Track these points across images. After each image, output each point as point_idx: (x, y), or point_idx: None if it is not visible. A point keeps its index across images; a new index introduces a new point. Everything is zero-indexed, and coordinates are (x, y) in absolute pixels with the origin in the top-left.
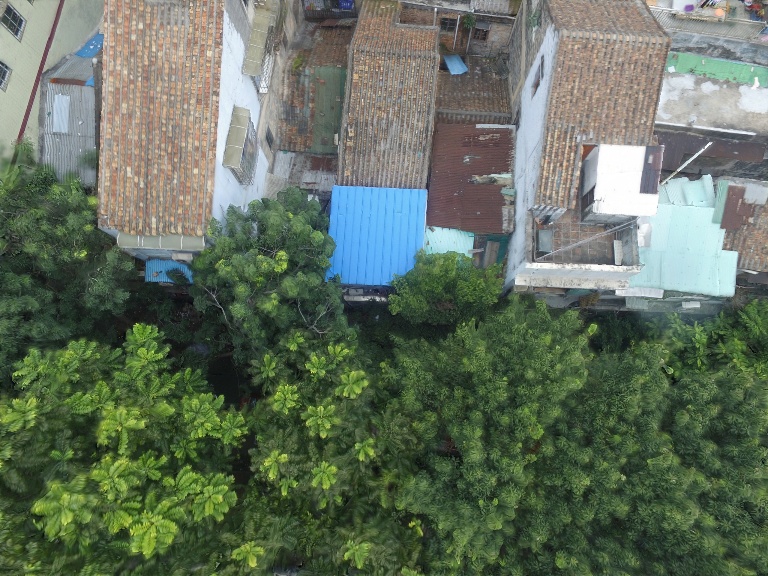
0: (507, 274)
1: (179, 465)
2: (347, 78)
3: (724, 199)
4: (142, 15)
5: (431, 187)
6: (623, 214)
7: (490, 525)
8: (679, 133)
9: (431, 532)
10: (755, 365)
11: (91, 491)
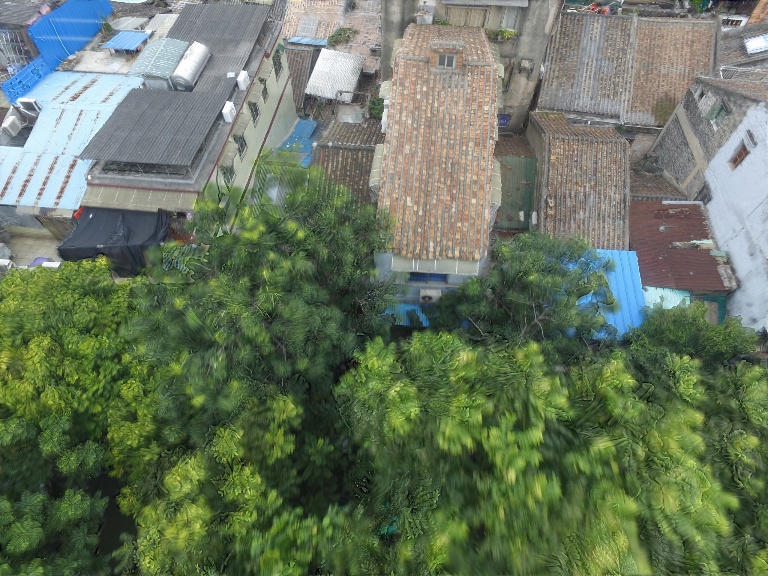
0: None
1: None
2: (545, 159)
3: None
4: (426, 81)
5: None
6: None
7: None
8: None
9: None
10: None
11: None
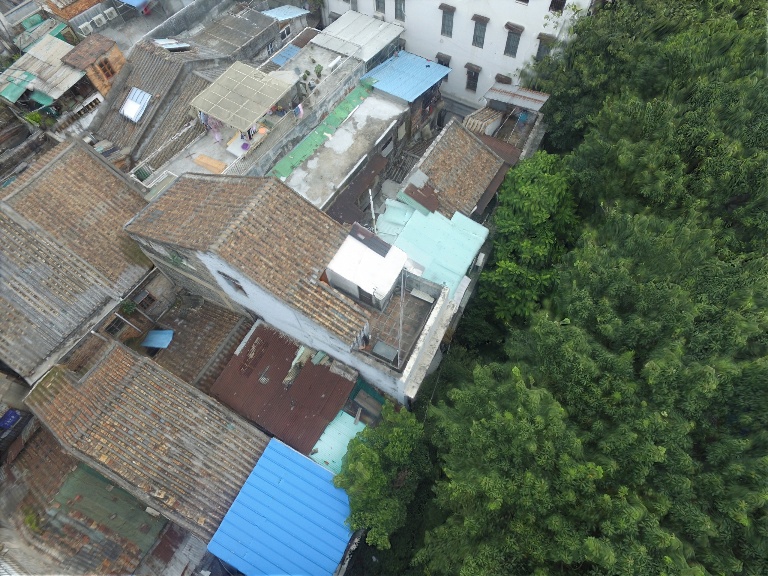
0: (394, 397)
1: None
2: (97, 469)
3: (412, 200)
4: None
5: (270, 430)
6: (396, 278)
7: None
8: (337, 199)
9: None
10: (546, 242)
11: None
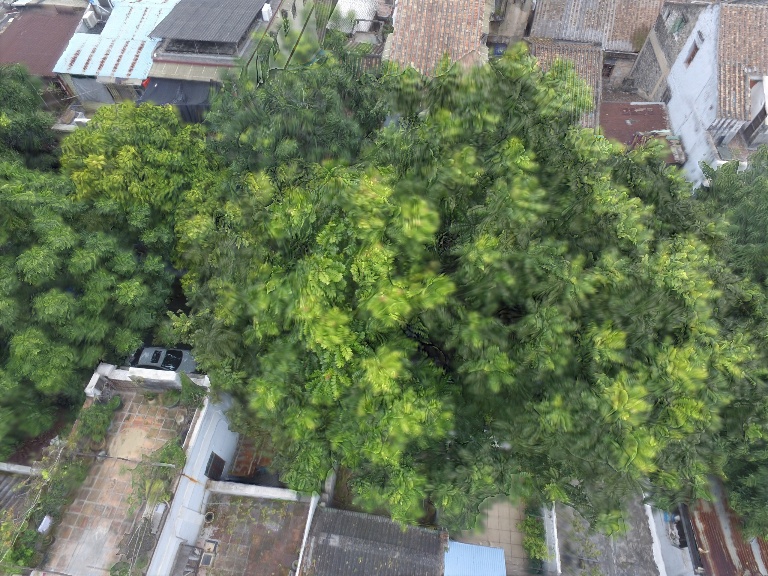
0: None
1: None
2: None
3: None
4: None
5: None
6: None
7: None
8: None
9: None
10: None
11: None
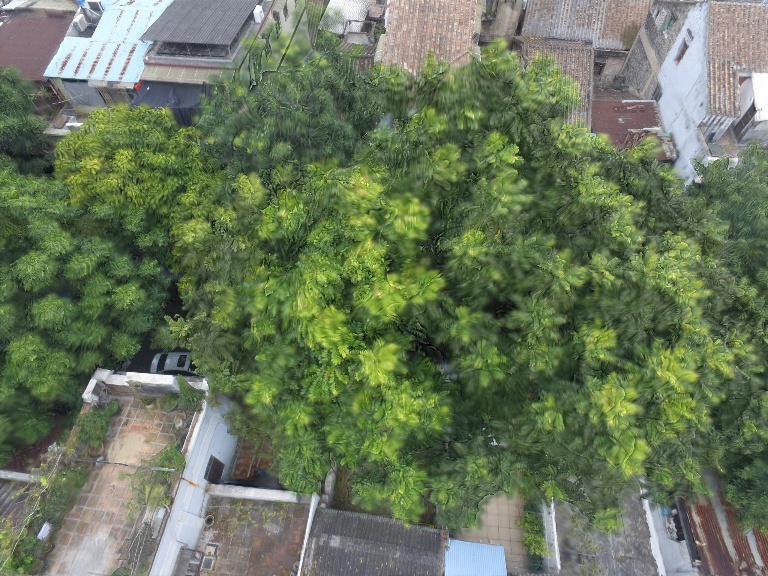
0: None
1: None
2: None
3: None
4: None
5: None
6: None
7: None
8: None
9: None
10: None
11: None
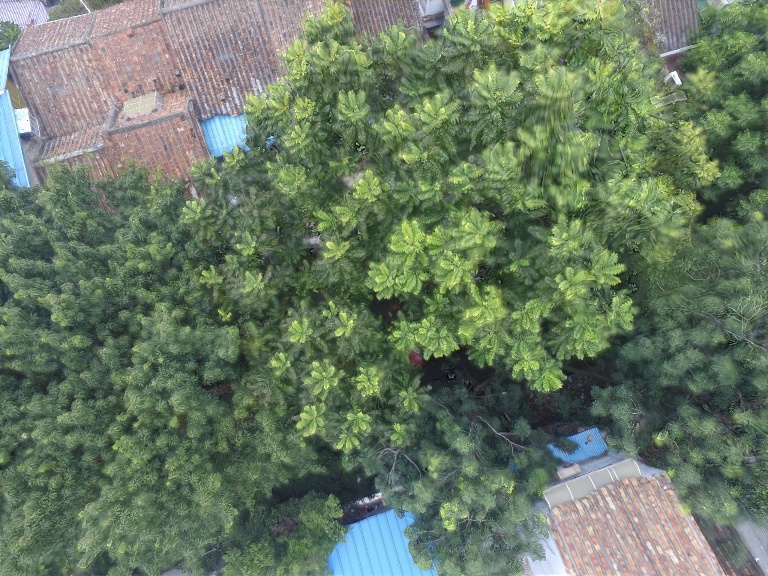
0: None
1: (436, 288)
2: None
3: None
4: None
5: None
6: None
7: (145, 346)
8: None
9: (215, 314)
10: None
11: (465, 253)
